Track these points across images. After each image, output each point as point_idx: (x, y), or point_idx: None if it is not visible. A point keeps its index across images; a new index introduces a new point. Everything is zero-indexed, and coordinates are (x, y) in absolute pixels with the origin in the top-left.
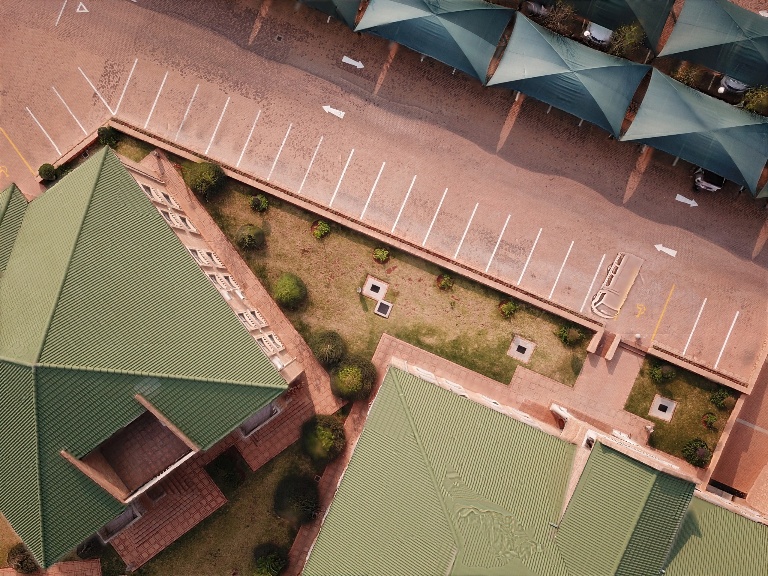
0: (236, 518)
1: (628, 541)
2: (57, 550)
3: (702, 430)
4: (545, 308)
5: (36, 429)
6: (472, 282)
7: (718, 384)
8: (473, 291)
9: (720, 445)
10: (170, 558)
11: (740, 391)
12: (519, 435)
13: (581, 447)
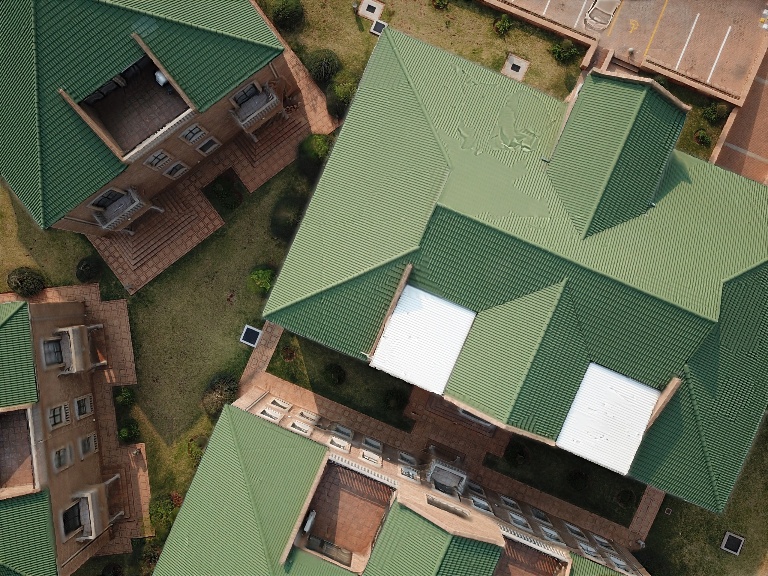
0: (233, 240)
1: (618, 156)
2: (56, 208)
3: (694, 146)
4: (539, 22)
5: (35, 60)
6: (467, 1)
7: (710, 98)
8: (468, 10)
9: (712, 159)
10: (168, 281)
11: (732, 103)
12: (512, 90)
13: (573, 99)
